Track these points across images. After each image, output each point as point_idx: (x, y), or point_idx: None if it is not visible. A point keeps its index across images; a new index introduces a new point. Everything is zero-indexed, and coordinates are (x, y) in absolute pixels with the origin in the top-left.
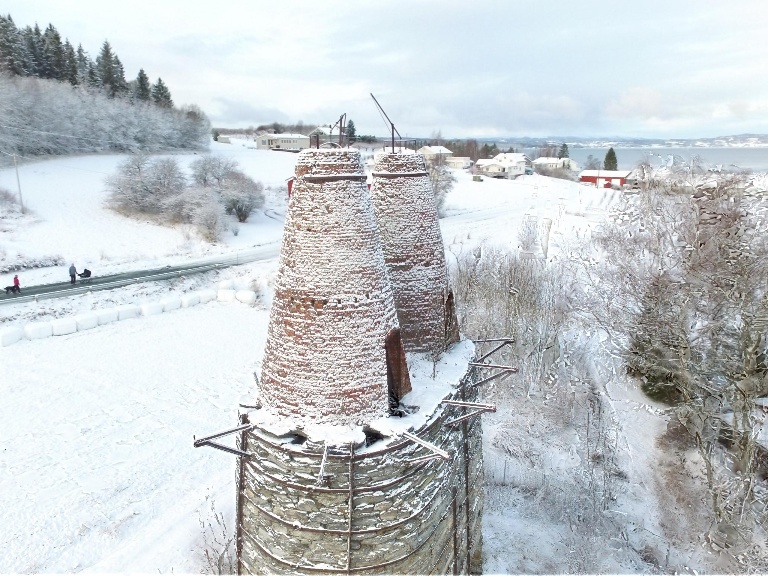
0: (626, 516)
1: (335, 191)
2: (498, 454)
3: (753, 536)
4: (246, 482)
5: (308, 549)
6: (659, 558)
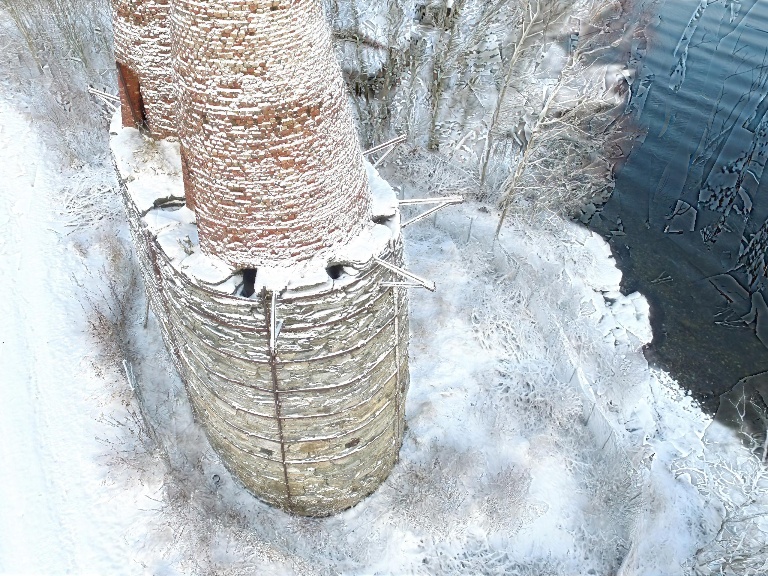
0: None
1: None
2: None
3: None
4: (279, 350)
5: (370, 355)
6: None
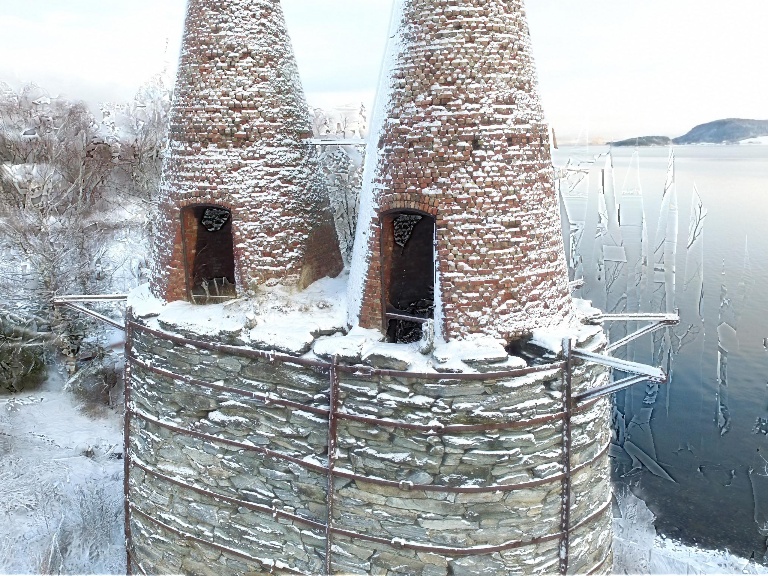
0: None
1: None
2: (24, 518)
3: None
4: (572, 449)
5: None
6: None
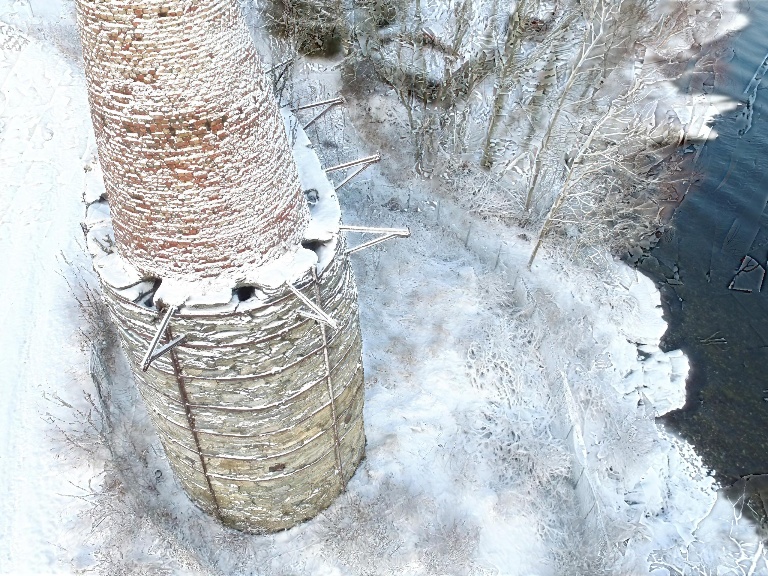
0: (370, 182)
1: None
2: None
3: (445, 154)
4: (184, 364)
5: (290, 382)
6: (402, 203)
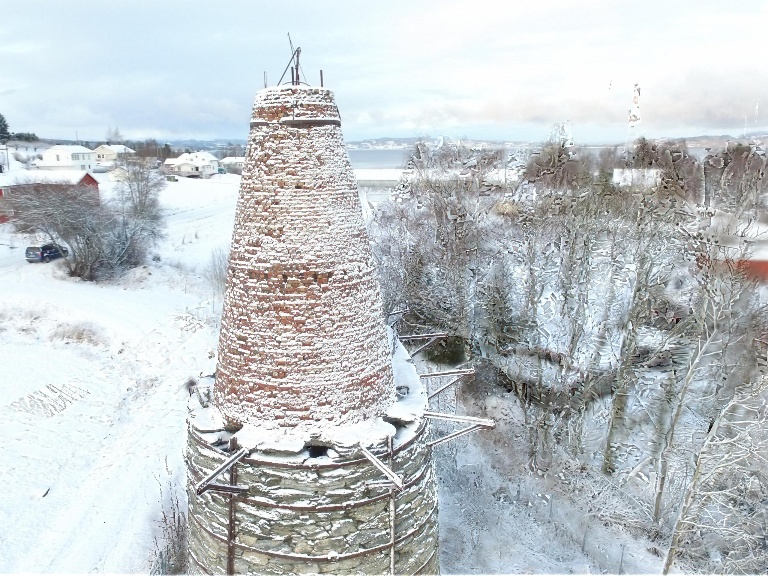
0: (478, 466)
1: (324, 138)
2: None
3: (561, 455)
4: (239, 528)
5: None
6: (511, 495)
